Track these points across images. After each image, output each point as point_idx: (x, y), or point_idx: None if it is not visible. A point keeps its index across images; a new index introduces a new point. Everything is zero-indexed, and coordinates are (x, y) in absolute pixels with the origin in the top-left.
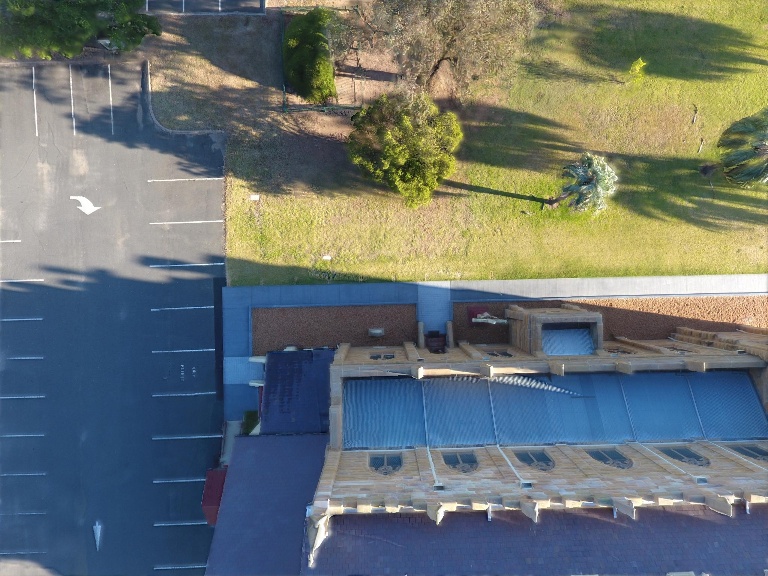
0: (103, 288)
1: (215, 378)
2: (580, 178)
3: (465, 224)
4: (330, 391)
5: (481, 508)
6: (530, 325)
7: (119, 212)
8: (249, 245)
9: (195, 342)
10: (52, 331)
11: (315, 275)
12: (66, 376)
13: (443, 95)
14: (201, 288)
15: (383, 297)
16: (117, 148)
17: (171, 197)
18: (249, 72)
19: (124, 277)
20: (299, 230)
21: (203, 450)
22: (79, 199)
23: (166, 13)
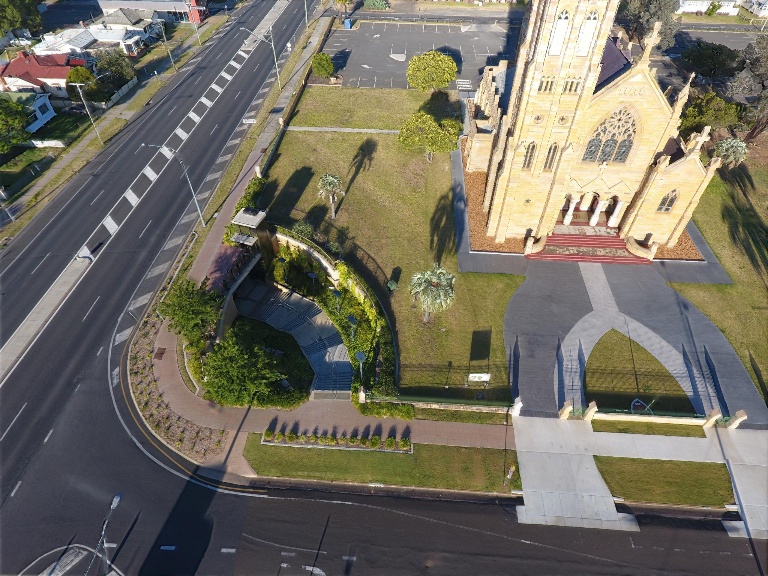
0: None
1: None
2: None
3: None
4: None
5: None
6: None
7: None
8: None
9: None
10: None
11: None
12: None
13: None
14: None
15: None
16: None
17: None
18: None
19: None
20: None
21: None
22: None
23: None
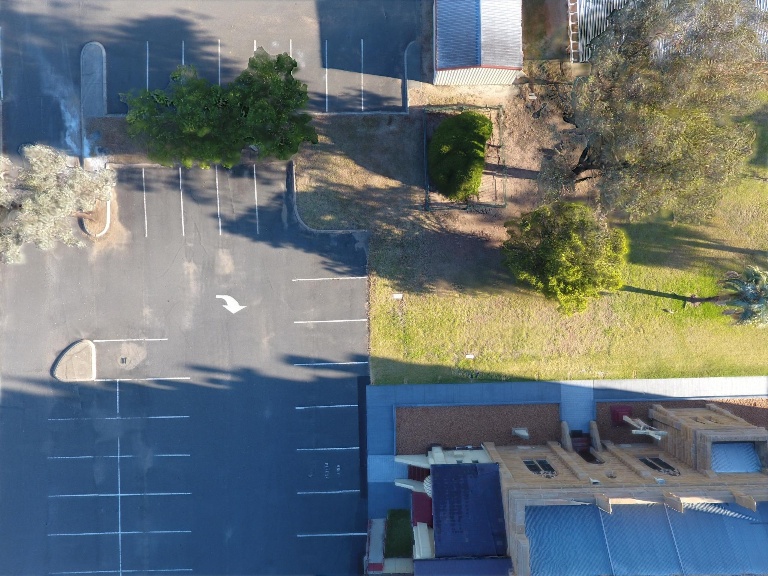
0: (249, 386)
1: (359, 476)
2: (749, 296)
3: (607, 323)
4: (499, 509)
5: None
6: (696, 441)
7: (264, 311)
8: (393, 344)
9: (339, 440)
10: (199, 429)
11: (458, 374)
12: (212, 473)
13: (584, 192)
14: (345, 387)
15: (526, 396)
16: (262, 247)
17: (315, 296)
18: (392, 171)
19: (269, 376)
20: (442, 329)
21: (348, 547)
22: (225, 298)
23: (310, 113)
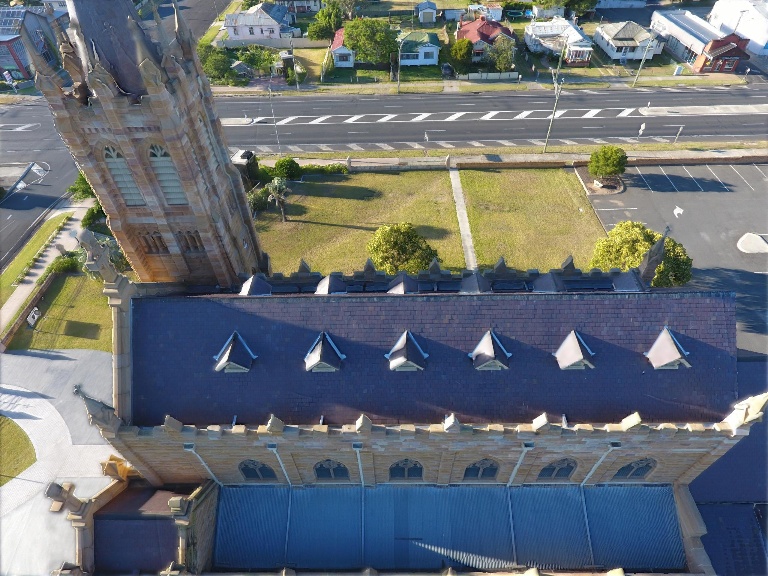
0: None
1: None
2: None
3: None
4: None
5: (584, 426)
6: None
7: None
8: None
9: None
10: None
11: None
12: None
13: None
14: None
15: None
16: None
17: None
18: None
19: None
20: None
21: None
22: None
23: None
